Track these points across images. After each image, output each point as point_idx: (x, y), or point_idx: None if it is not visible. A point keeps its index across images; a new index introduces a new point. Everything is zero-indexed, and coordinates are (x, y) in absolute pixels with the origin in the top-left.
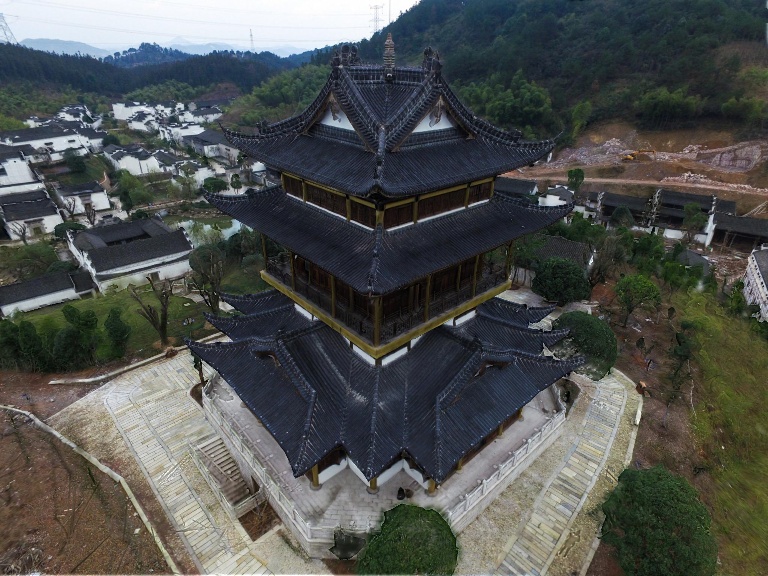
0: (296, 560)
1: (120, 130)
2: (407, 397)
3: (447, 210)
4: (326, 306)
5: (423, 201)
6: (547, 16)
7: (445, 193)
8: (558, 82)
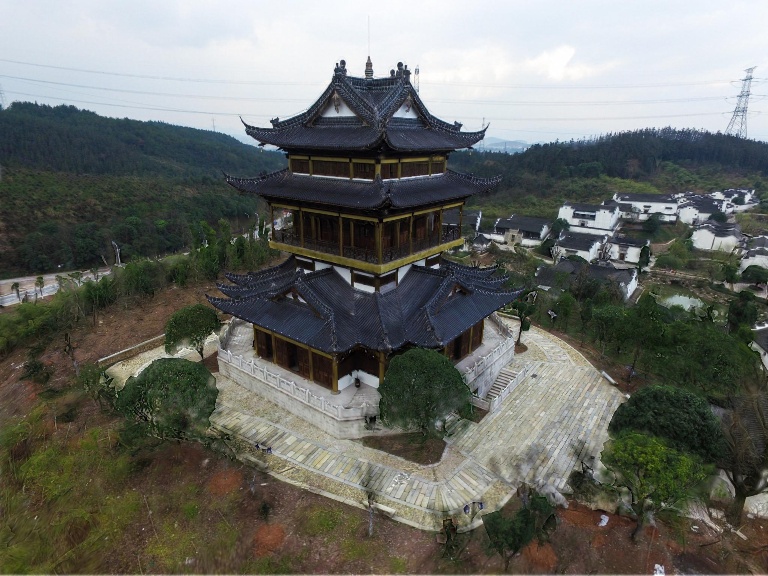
0: None
1: (767, 216)
2: None
3: (336, 176)
4: None
5: (317, 162)
6: None
7: (332, 161)
8: None
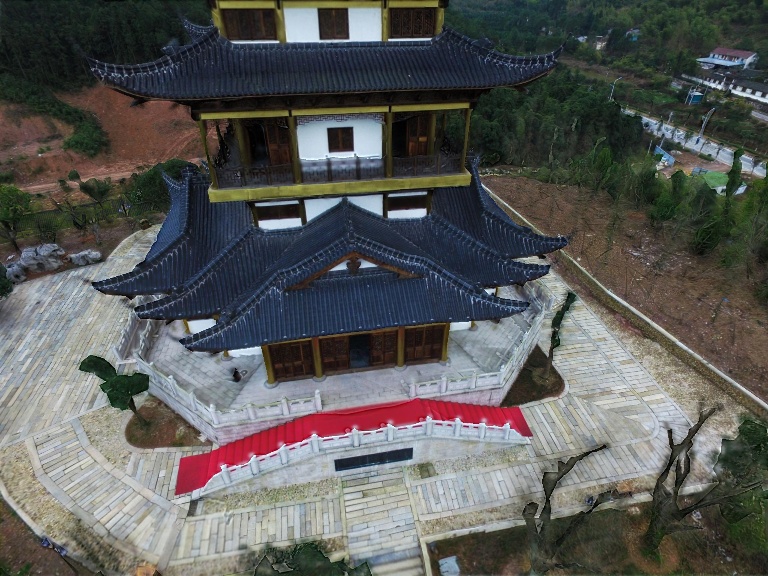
0: None
1: None
2: None
3: None
4: None
5: None
6: None
7: None
8: None
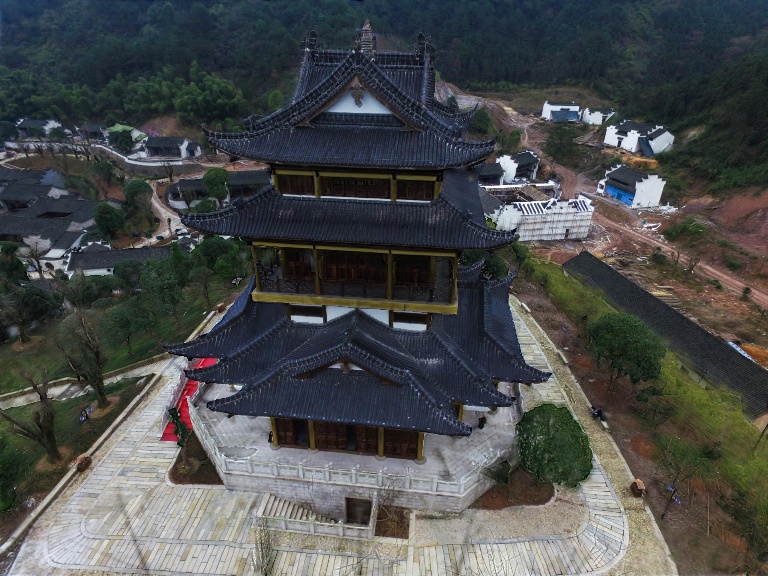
0: (453, 523)
1: None
2: (457, 344)
3: None
4: (376, 293)
5: None
6: (197, 6)
7: None
8: (236, 73)
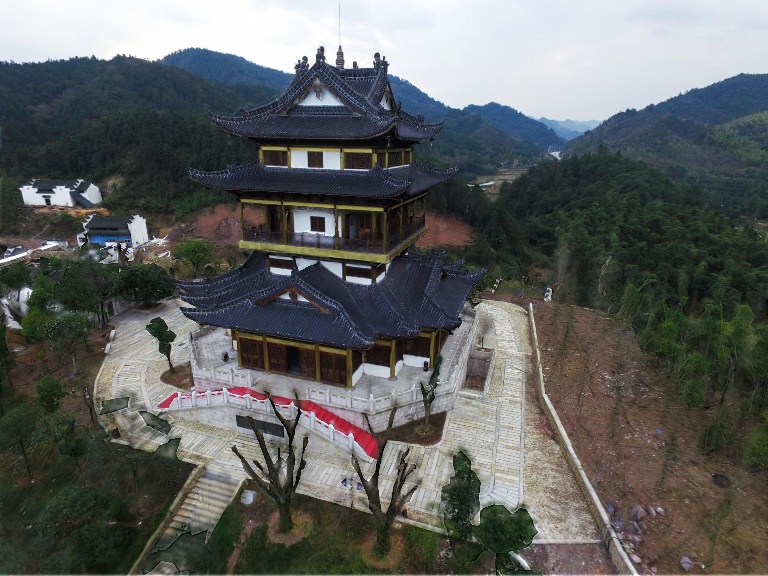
0: None
1: None
2: None
3: None
4: None
5: None
6: None
7: None
8: None
